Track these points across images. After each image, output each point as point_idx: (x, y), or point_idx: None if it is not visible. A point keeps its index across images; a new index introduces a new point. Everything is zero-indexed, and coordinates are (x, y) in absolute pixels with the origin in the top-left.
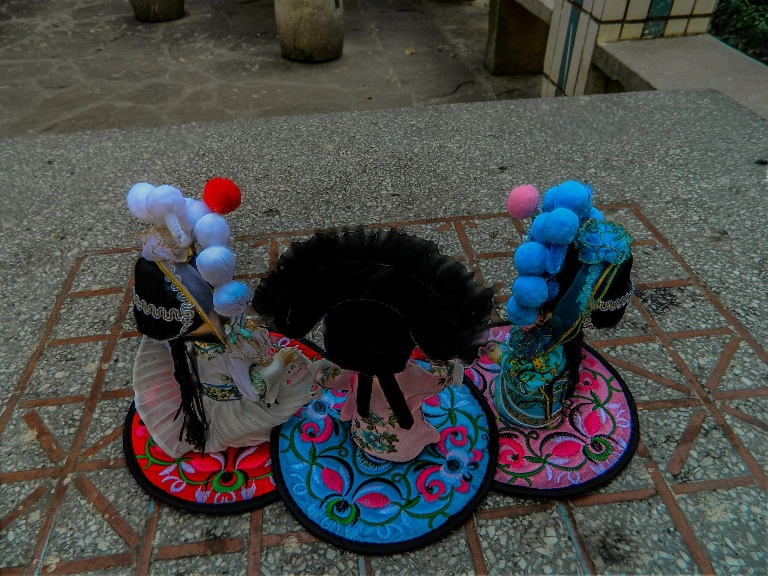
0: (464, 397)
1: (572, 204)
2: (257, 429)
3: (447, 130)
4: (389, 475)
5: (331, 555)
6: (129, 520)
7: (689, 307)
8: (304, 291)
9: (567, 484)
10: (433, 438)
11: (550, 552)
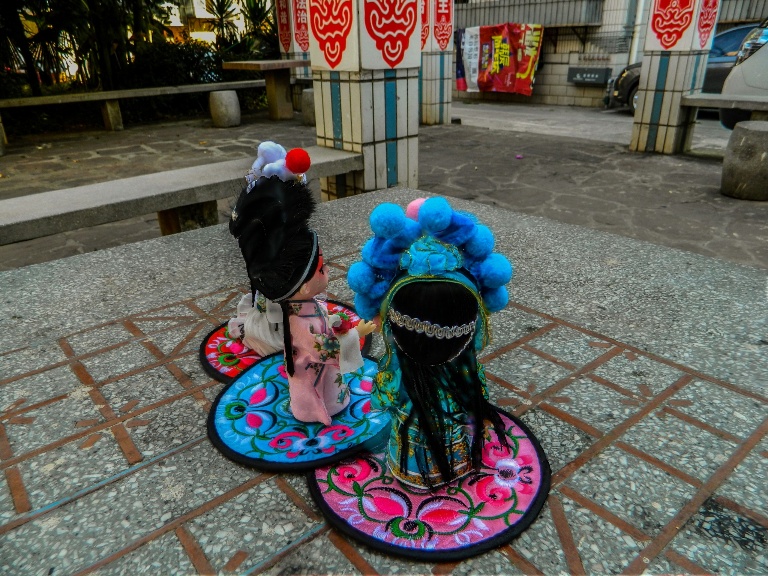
0: (384, 419)
1: (421, 213)
2: (257, 336)
3: (761, 294)
4: (281, 419)
5: (201, 422)
6: (186, 347)
7: (763, 563)
8: (250, 207)
9: (343, 516)
10: (323, 417)
11: (267, 533)
